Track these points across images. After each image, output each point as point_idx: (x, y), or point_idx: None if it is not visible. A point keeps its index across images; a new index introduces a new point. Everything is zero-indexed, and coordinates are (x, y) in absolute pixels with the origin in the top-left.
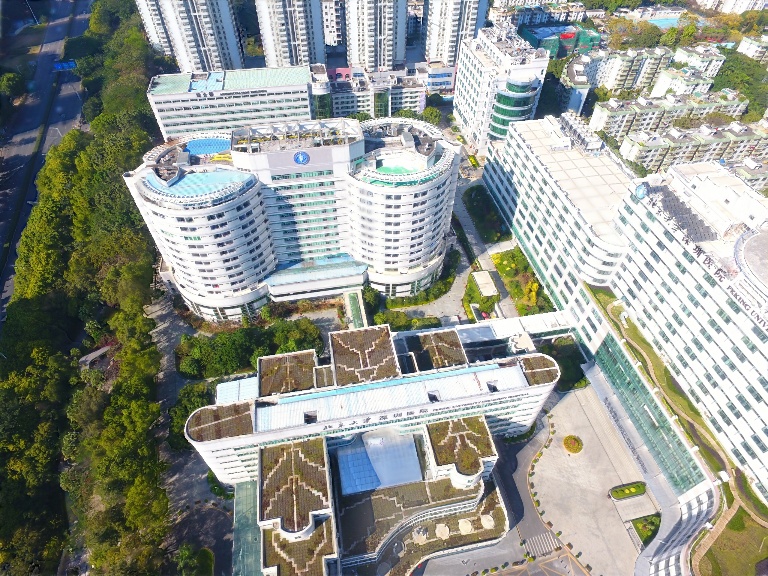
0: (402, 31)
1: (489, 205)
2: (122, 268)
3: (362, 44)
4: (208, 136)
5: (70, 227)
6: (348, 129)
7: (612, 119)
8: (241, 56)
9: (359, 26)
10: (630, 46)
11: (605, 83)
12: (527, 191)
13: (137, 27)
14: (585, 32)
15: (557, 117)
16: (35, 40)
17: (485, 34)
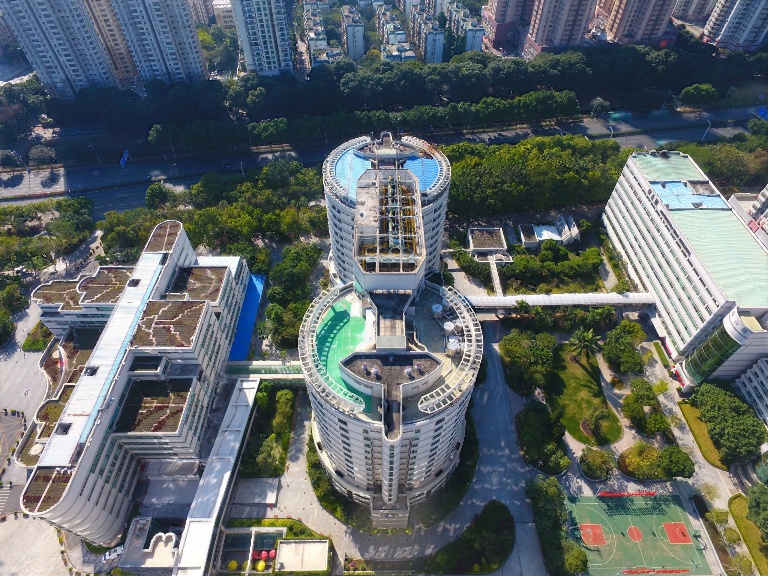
0: None
1: None
2: None
3: None
4: None
5: None
6: None
7: None
8: None
9: None
10: None
11: None
12: None
13: None
14: None
15: None
16: None
17: None
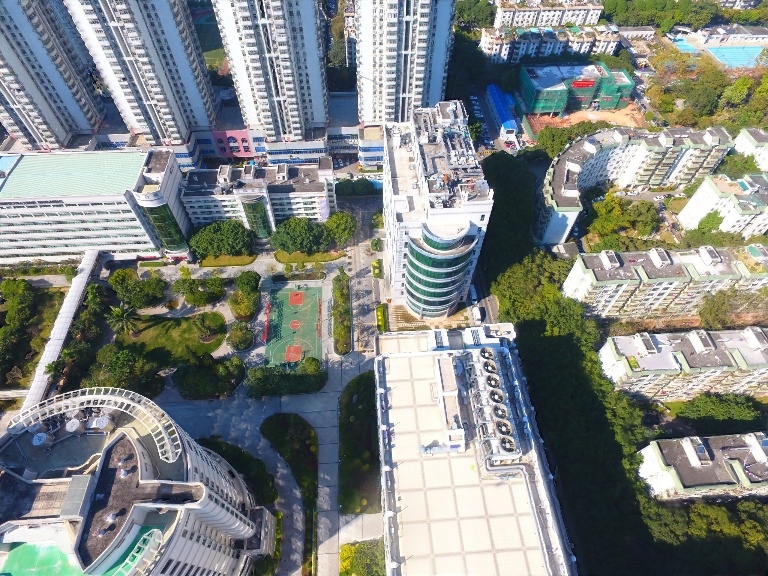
0: (317, 86)
1: (372, 426)
2: None
3: None
4: None
5: None
6: None
7: (599, 289)
8: (85, 111)
9: (250, 78)
10: (678, 96)
11: (621, 174)
12: None
13: None
14: (610, 79)
15: (522, 255)
16: None
17: (415, 124)
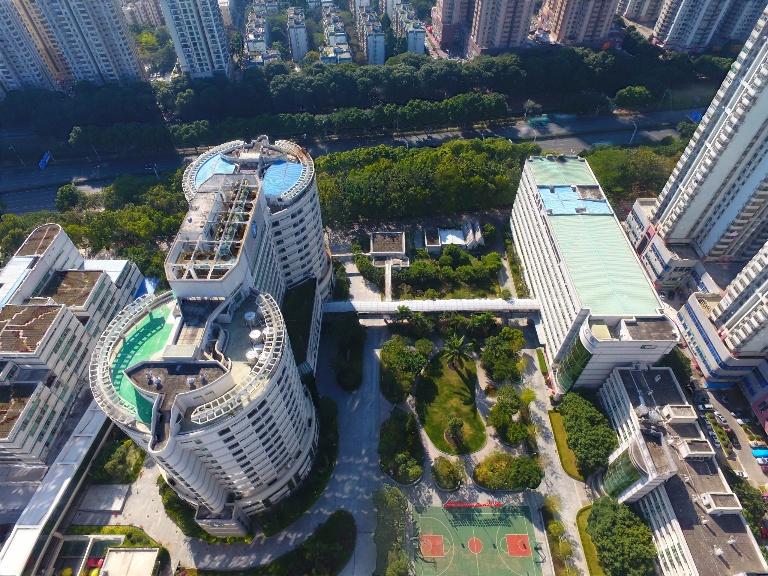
0: None
1: None
2: None
3: None
4: None
5: None
6: (235, 279)
7: None
8: (722, 241)
9: None
10: None
11: None
12: None
13: None
14: None
15: None
16: None
17: None
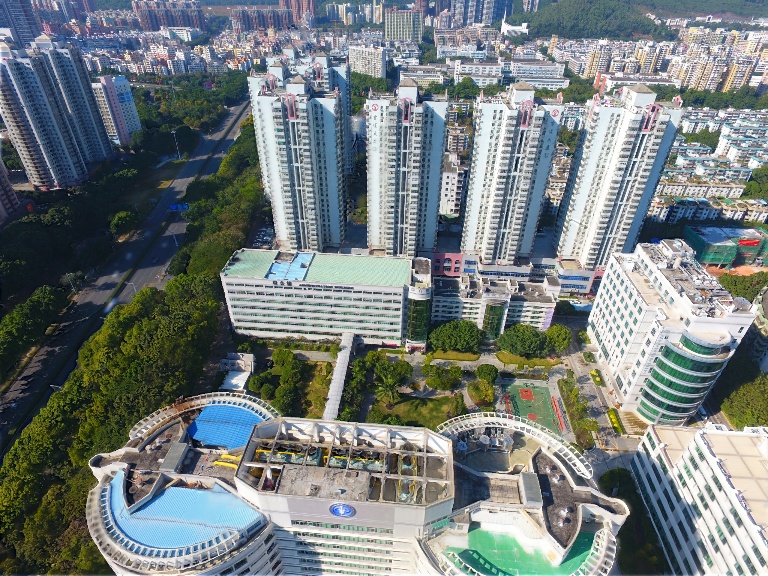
0: (532, 224)
1: (641, 521)
2: (81, 551)
3: (481, 232)
4: (234, 400)
5: (74, 435)
6: (433, 444)
7: None
8: (342, 229)
9: (481, 214)
10: None
11: None
12: (732, 574)
13: (257, 176)
14: None
15: (750, 376)
16: (170, 175)
17: (648, 254)
